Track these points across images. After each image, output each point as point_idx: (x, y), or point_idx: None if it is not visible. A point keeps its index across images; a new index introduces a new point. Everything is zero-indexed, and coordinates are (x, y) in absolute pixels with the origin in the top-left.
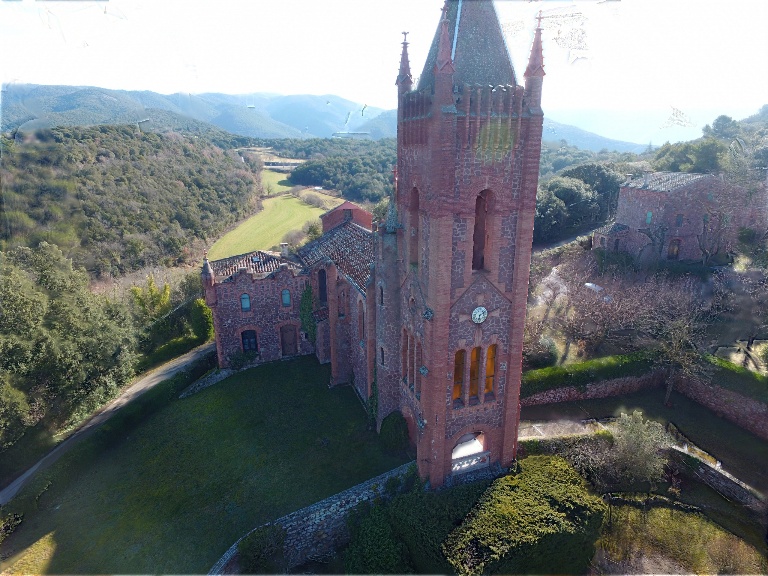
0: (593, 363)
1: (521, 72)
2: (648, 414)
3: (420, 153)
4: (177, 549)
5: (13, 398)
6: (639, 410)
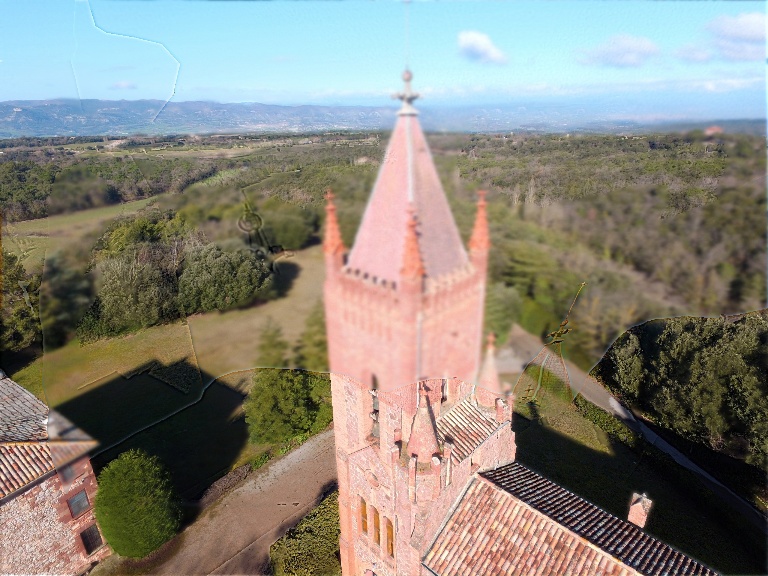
0: None
1: (425, 354)
2: None
3: None
4: (527, 462)
5: (702, 412)
6: None
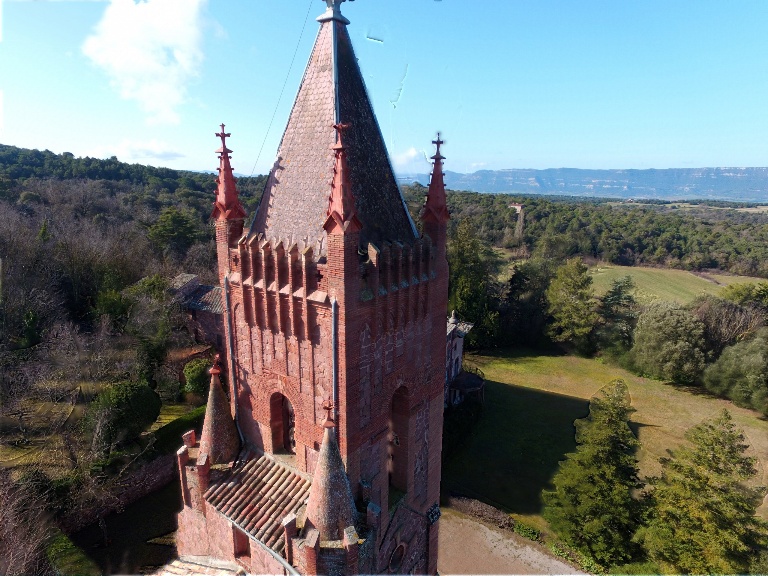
0: (86, 574)
1: None
2: (133, 558)
3: (411, 331)
4: None
5: None
6: (126, 565)
